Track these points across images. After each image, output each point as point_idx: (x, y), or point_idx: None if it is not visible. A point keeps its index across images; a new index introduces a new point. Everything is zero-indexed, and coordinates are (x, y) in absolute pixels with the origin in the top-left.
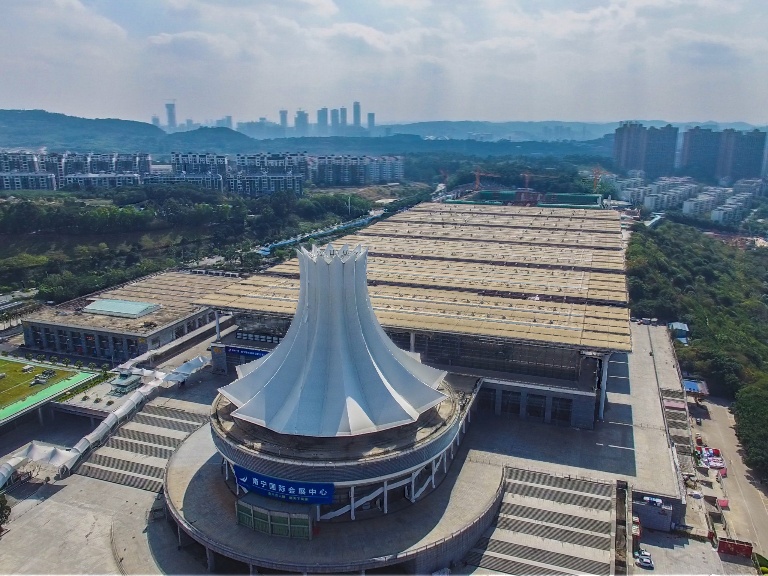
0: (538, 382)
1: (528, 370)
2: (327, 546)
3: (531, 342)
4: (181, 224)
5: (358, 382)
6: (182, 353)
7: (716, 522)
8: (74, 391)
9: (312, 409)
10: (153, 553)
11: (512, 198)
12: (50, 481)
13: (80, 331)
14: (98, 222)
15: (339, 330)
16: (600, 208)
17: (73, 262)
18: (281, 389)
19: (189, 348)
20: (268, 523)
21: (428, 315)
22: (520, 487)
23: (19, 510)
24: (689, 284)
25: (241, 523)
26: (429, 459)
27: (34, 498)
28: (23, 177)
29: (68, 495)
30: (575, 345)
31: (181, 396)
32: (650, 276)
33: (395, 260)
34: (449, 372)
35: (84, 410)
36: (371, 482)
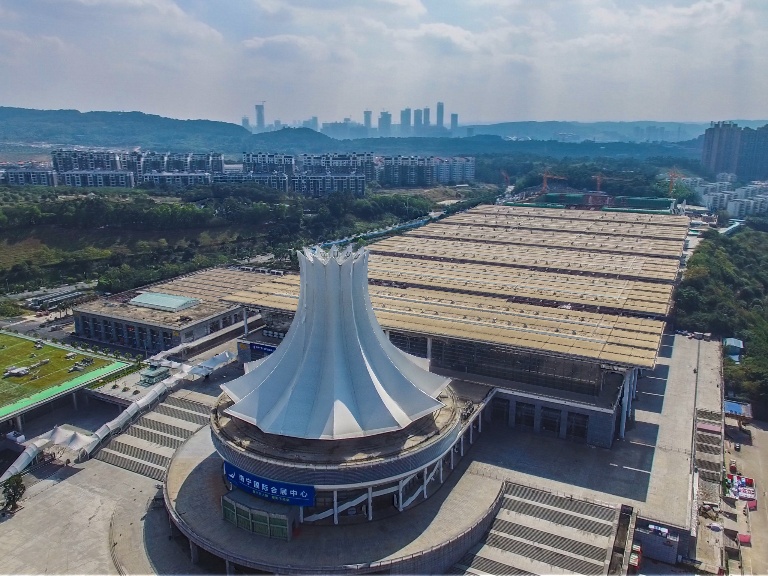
0: (554, 395)
1: (546, 382)
2: (303, 548)
3: (546, 353)
4: (239, 222)
5: (351, 385)
6: (215, 347)
7: (732, 558)
8: (107, 379)
9: (301, 410)
10: (145, 540)
11: (579, 201)
12: (70, 463)
13: (122, 322)
14: (160, 218)
15: (334, 332)
16: (670, 213)
17: (134, 256)
18: (275, 388)
19: (223, 343)
20: (249, 521)
21: (447, 320)
22: (517, 504)
23: (36, 489)
24: (757, 297)
25: (226, 518)
26: (417, 468)
27: (52, 479)
28: (105, 175)
29: (83, 478)
30: (592, 358)
31: (203, 389)
32: (709, 287)
33: (433, 263)
34: (463, 380)
35: (111, 398)
36: (353, 487)
